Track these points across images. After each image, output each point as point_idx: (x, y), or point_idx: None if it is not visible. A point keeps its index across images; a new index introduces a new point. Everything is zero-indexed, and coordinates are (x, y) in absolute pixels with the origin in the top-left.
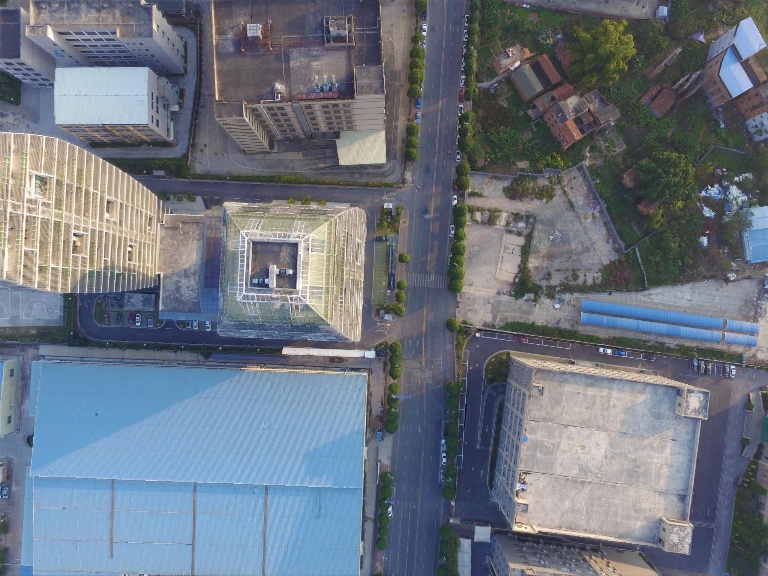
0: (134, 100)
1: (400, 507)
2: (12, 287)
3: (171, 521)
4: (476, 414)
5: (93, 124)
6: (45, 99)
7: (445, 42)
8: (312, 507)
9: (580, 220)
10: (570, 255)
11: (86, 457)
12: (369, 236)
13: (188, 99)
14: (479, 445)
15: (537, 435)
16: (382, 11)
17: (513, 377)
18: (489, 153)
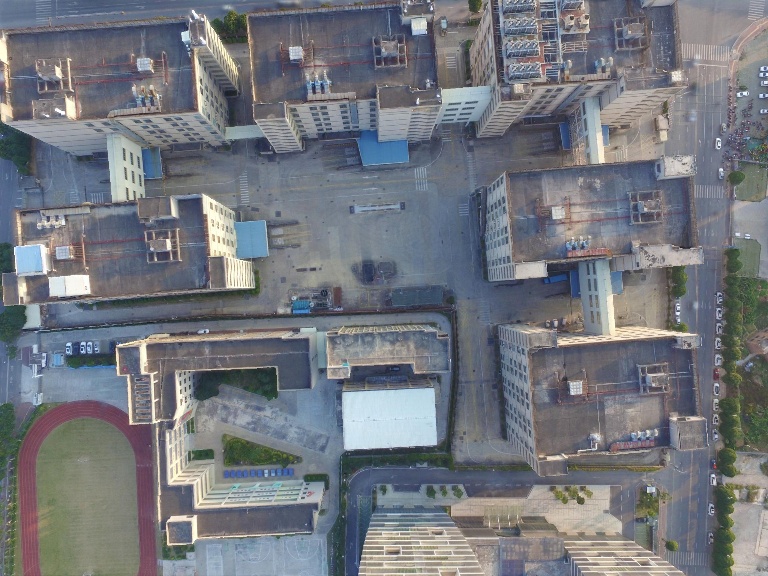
0: (423, 423)
1: None
2: None
3: None
4: None
5: (382, 448)
6: (302, 391)
7: (698, 320)
8: None
9: None
10: None
11: None
12: (629, 517)
13: (444, 386)
14: None
15: None
16: (634, 290)
17: None
18: (749, 435)
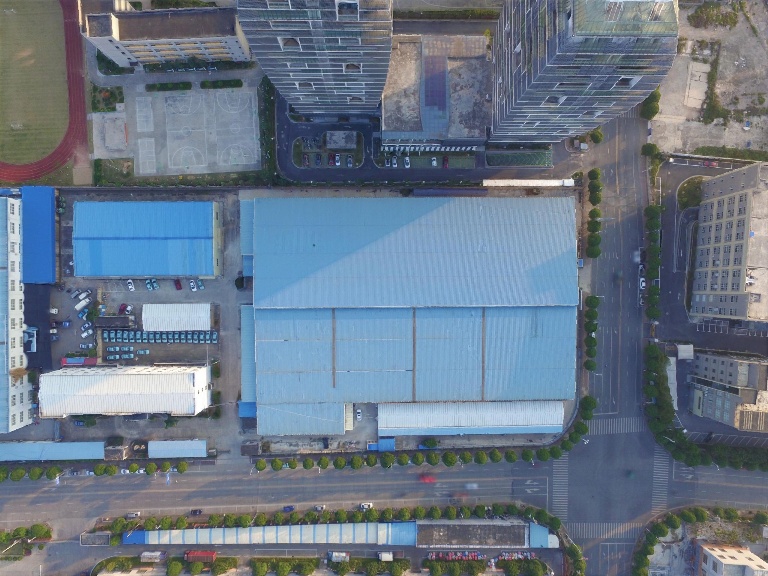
0: None
1: (602, 333)
2: (367, 9)
3: (391, 348)
4: (671, 239)
5: None
6: None
7: None
8: (528, 327)
9: (763, 45)
10: (755, 80)
11: (307, 287)
12: None
13: None
14: (676, 268)
15: (760, 231)
16: None
17: (713, 194)
18: None
